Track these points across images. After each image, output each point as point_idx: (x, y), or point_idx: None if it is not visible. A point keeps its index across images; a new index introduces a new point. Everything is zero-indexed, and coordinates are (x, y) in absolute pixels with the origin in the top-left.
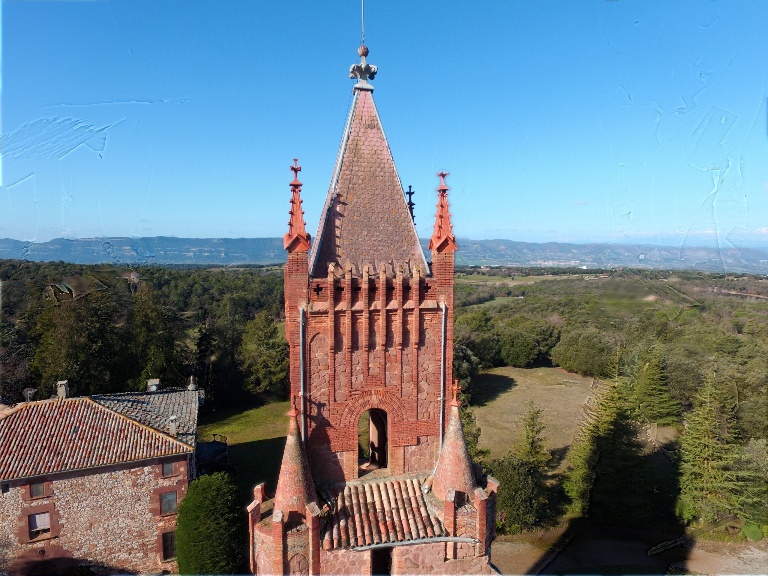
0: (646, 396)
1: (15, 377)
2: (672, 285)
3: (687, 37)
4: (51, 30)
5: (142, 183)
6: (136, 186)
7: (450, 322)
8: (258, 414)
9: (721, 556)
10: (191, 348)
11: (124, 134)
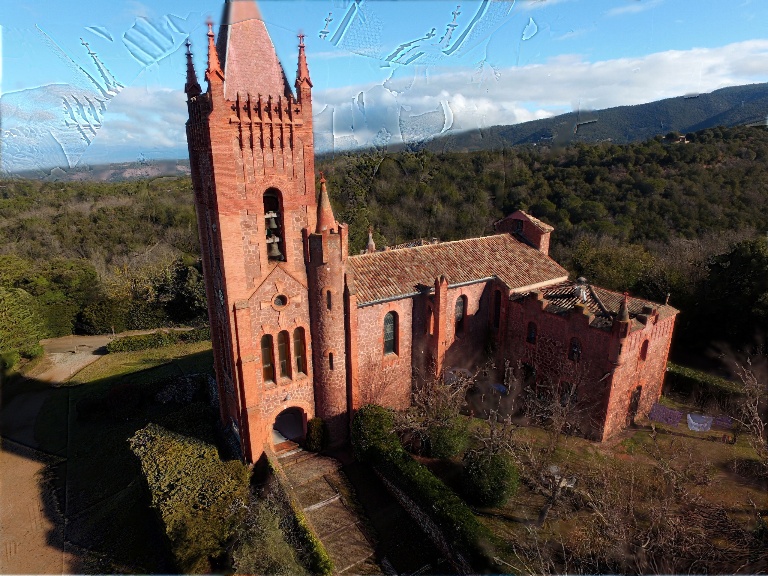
0: None
1: None
2: None
3: None
4: None
5: None
6: None
7: None
8: None
9: (53, 368)
10: None
11: None
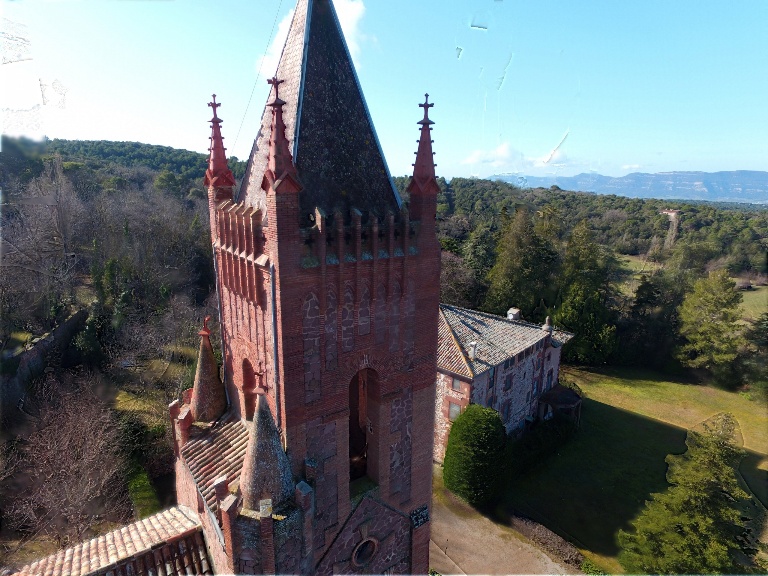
0: None
1: (464, 282)
2: None
3: None
4: None
5: (563, 116)
6: (555, 120)
7: (278, 289)
8: (678, 390)
9: None
10: (626, 294)
11: (547, 67)
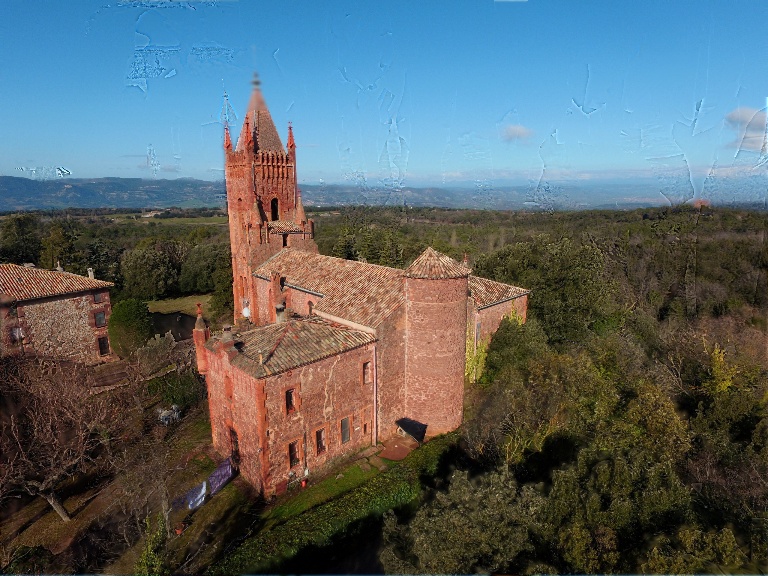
0: (362, 248)
1: None
2: (377, 199)
3: (373, 39)
4: (278, 106)
5: None
6: None
7: None
8: None
9: None
10: None
11: None
